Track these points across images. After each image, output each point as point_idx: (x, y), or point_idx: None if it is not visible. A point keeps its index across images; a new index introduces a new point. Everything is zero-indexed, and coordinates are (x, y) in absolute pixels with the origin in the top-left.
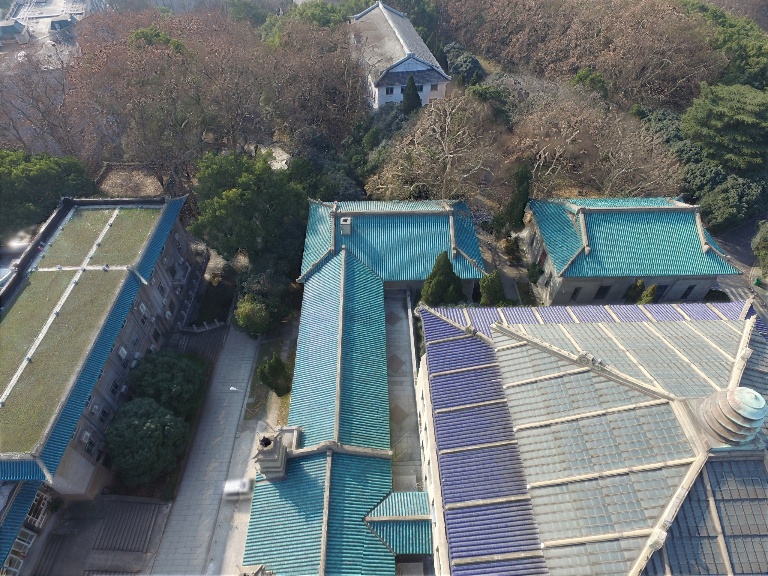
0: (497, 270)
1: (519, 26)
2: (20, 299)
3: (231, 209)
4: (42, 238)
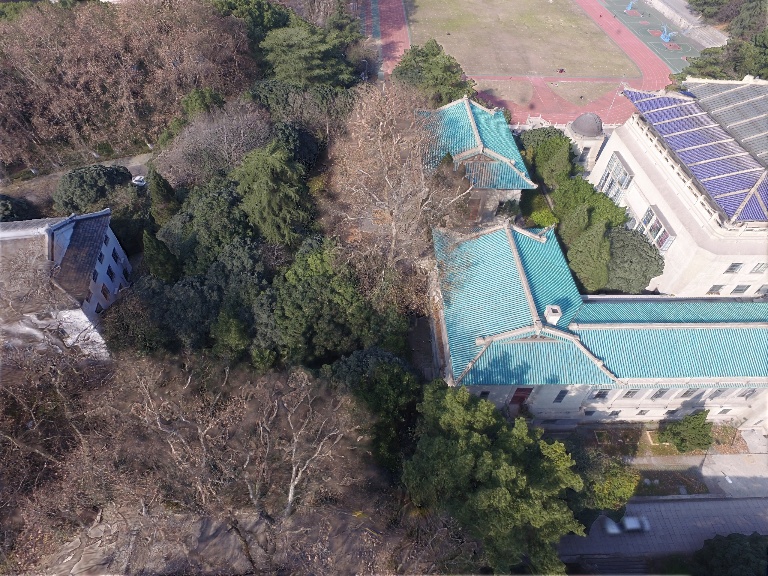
0: None
1: None
2: None
3: None
4: None
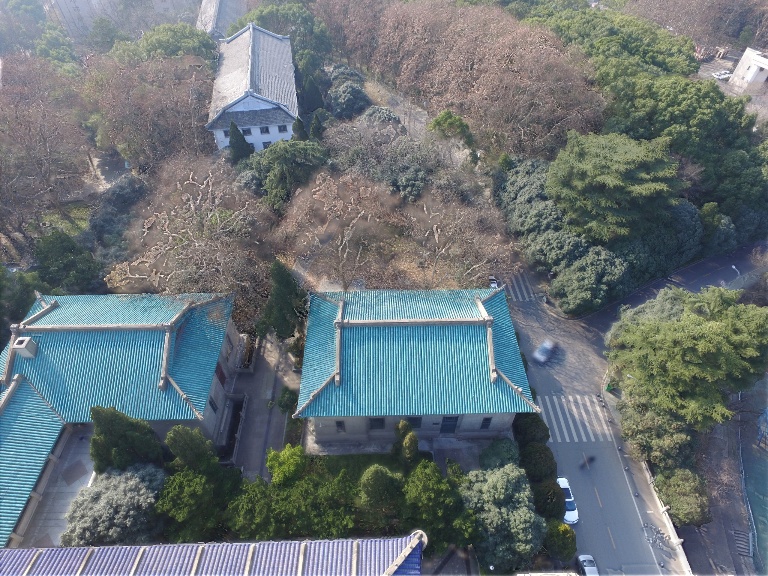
0: (276, 378)
1: (411, 50)
2: None
3: None
4: None
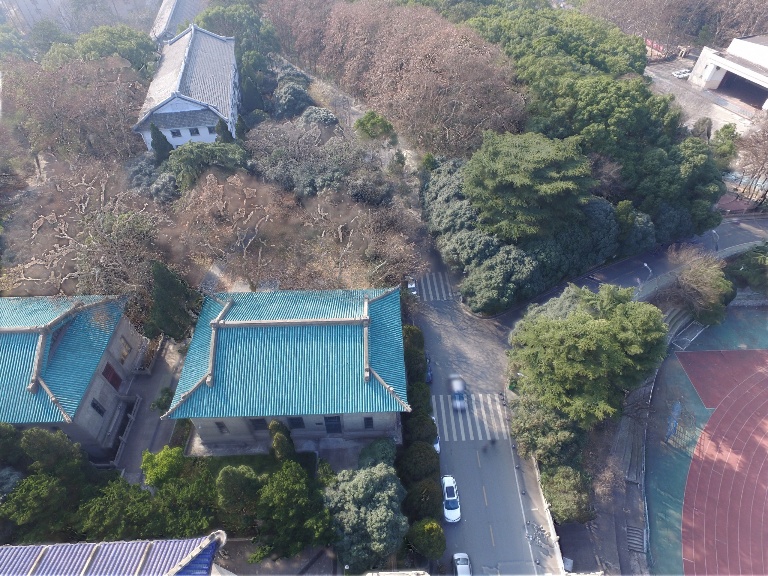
0: (173, 380)
1: None
2: None
3: None
4: None
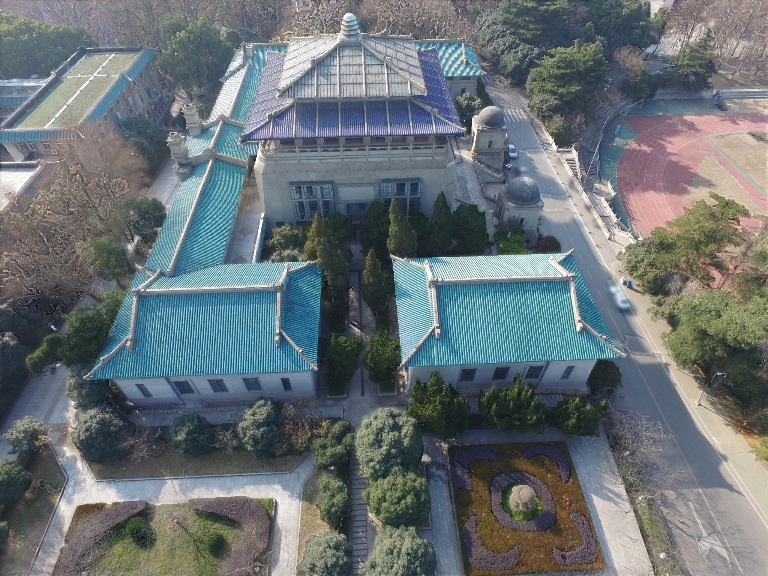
0: None
1: None
2: (59, 87)
3: (183, 48)
4: (68, 64)
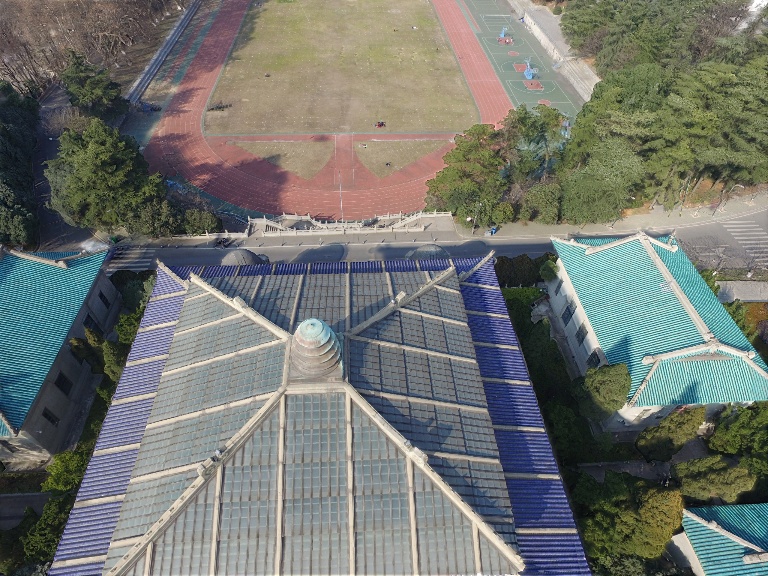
0: None
1: None
2: None
3: None
4: None
